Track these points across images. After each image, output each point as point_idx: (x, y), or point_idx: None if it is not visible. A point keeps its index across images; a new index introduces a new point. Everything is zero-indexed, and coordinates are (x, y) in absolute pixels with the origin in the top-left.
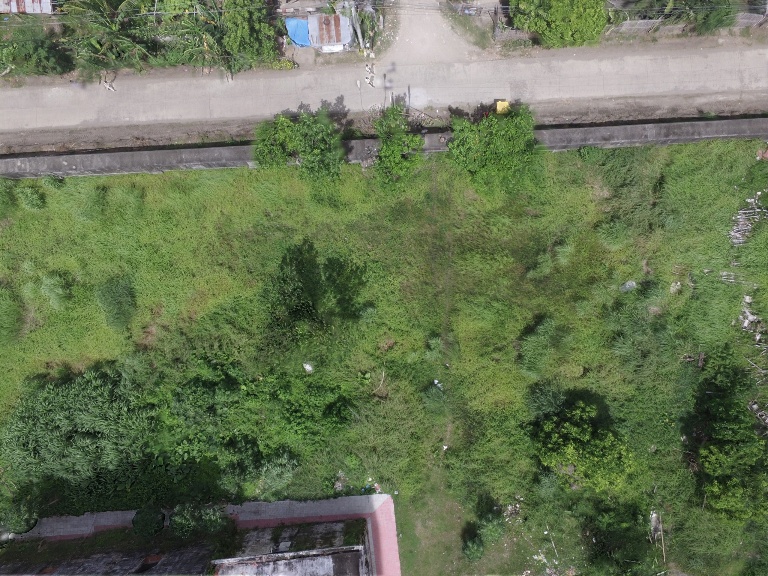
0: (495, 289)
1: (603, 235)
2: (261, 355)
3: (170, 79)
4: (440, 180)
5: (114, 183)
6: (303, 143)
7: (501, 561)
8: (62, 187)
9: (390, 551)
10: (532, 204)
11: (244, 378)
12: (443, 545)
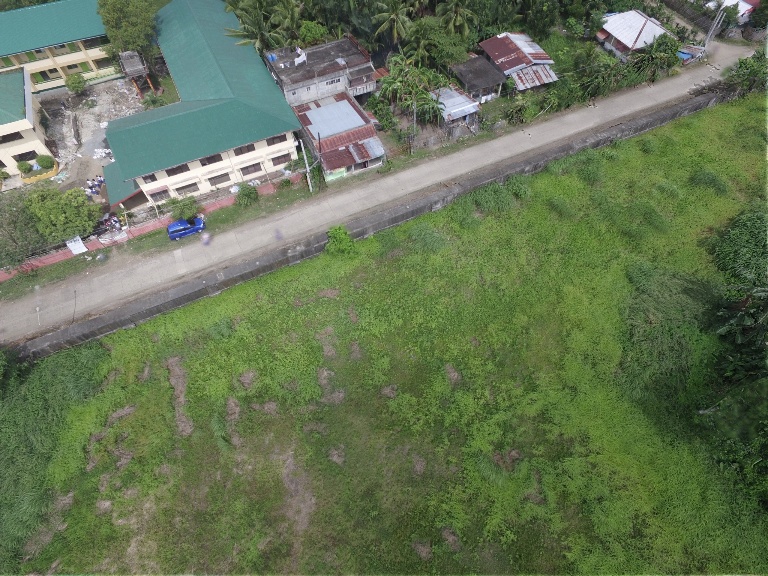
0: None
1: None
2: None
3: (621, 95)
4: None
5: None
6: (759, 62)
7: None
8: (619, 147)
9: None
10: None
11: None
12: None
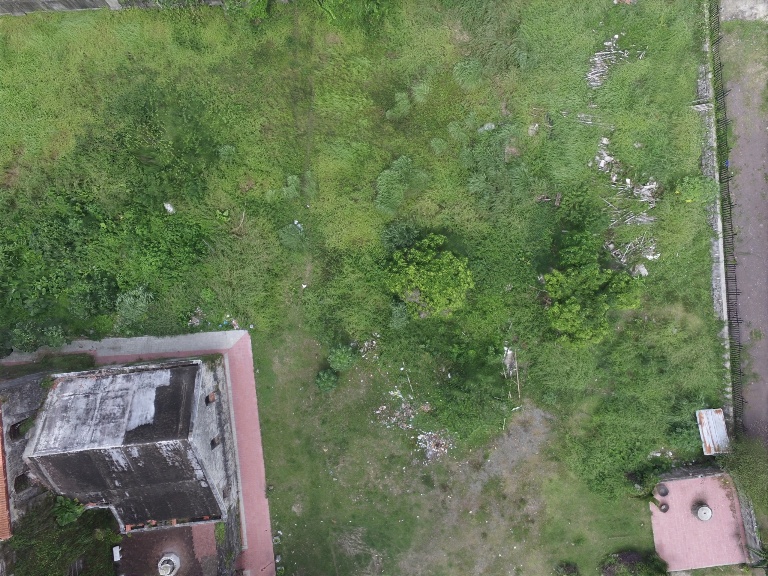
0: (356, 131)
1: (457, 72)
2: (120, 192)
3: None
4: (301, 24)
5: None
6: None
7: (357, 397)
8: None
9: (247, 386)
10: (391, 46)
11: (104, 217)
12: (300, 381)
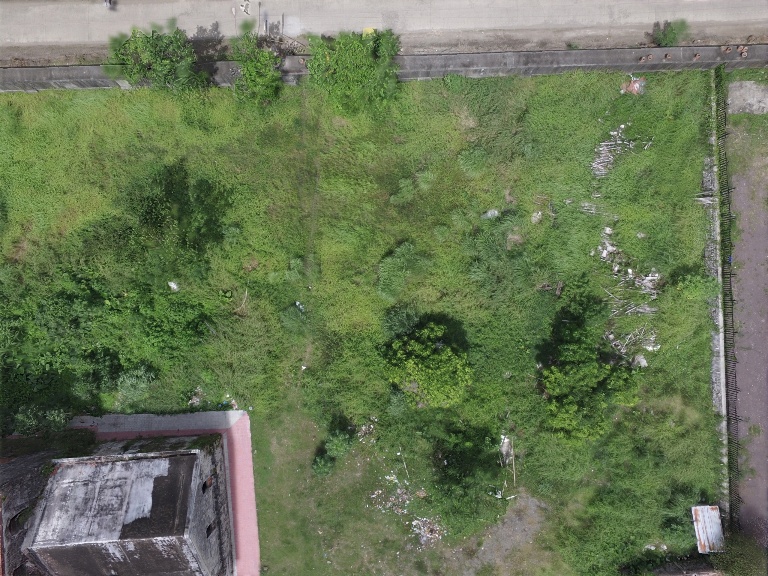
0: (359, 214)
1: (461, 161)
2: (125, 271)
3: (51, 3)
4: (308, 106)
5: None
6: (154, 54)
7: (354, 480)
8: None
9: (245, 467)
10: (397, 131)
11: (109, 293)
12: (297, 463)
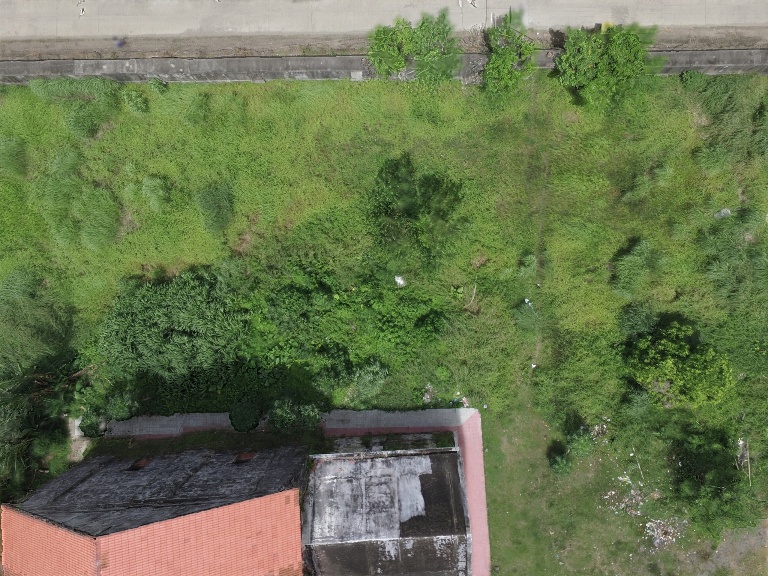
0: (589, 211)
1: (703, 159)
2: (355, 265)
3: None
4: (539, 101)
5: (216, 91)
6: (419, 45)
7: (586, 481)
8: (165, 92)
9: (475, 465)
10: (630, 128)
11: (337, 288)
12: (528, 462)
